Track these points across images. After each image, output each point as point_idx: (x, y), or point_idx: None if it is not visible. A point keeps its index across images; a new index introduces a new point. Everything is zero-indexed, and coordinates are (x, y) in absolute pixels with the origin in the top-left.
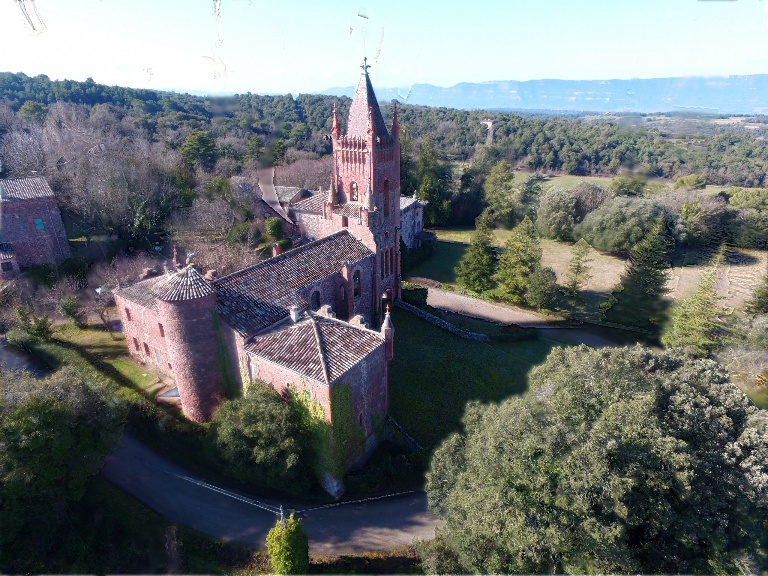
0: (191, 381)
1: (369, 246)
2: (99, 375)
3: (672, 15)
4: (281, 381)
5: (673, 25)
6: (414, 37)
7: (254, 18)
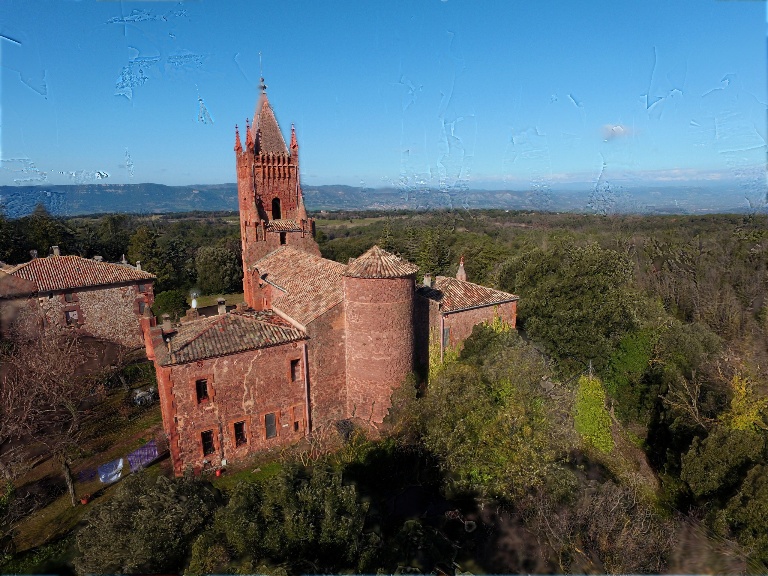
0: None
1: None
2: None
3: (340, 100)
4: None
5: (341, 107)
6: (50, 81)
7: None
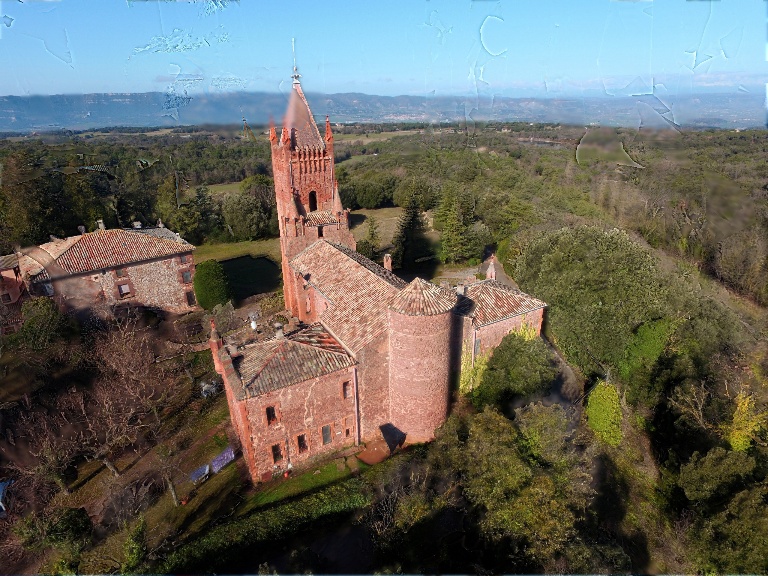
0: (446, 390)
1: (349, 247)
2: (316, 496)
3: (365, 49)
4: (504, 333)
5: (367, 56)
6: (69, 38)
7: None
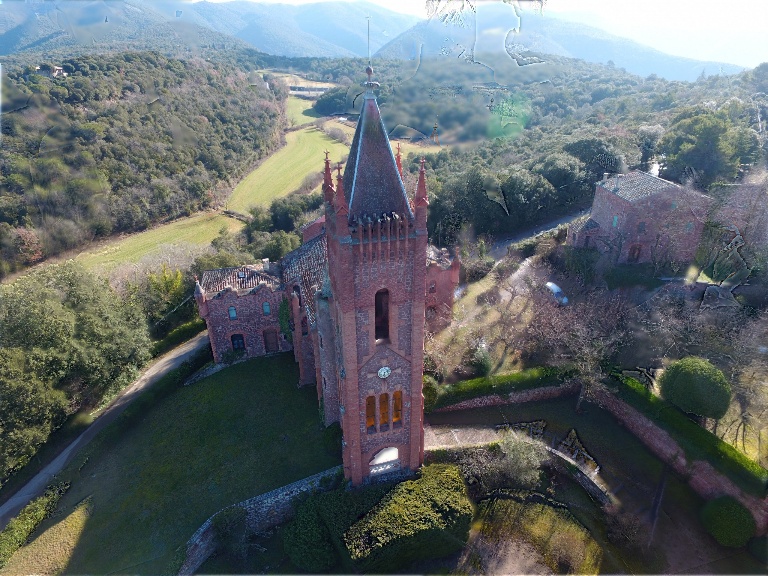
0: None
1: None
2: None
3: None
4: None
5: None
6: None
7: (487, 5)
